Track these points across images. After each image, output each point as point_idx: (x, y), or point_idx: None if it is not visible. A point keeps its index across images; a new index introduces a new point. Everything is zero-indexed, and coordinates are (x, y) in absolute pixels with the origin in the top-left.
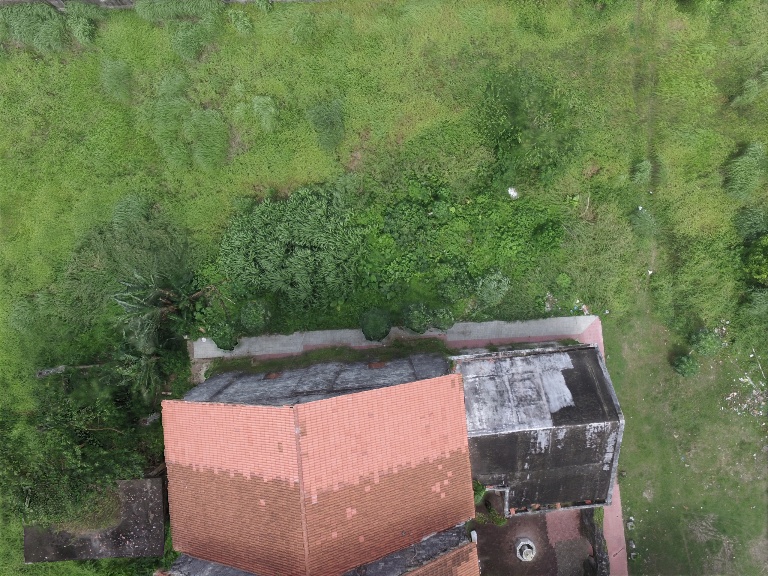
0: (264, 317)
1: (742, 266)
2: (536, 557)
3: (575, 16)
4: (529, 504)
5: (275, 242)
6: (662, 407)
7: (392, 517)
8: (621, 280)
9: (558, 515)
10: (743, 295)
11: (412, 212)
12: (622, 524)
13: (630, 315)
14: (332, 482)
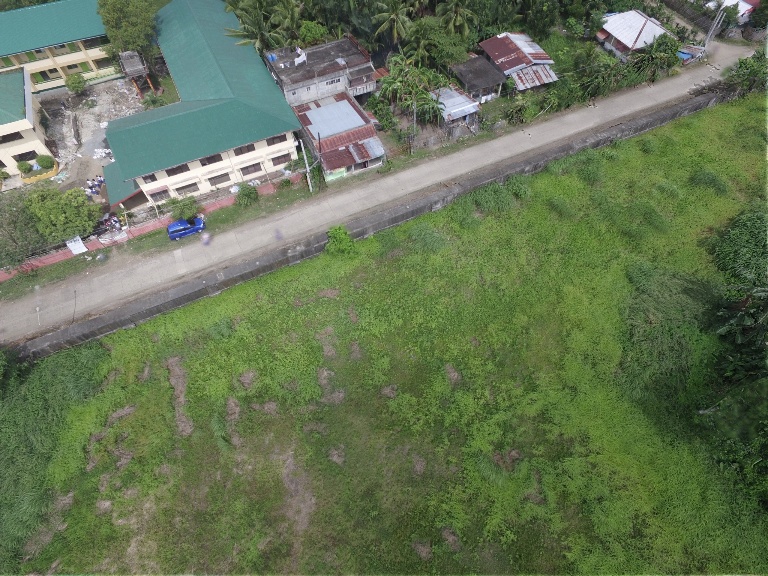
0: None
1: None
2: None
3: None
4: None
5: None
6: None
7: None
8: None
9: None
10: None
11: None
12: None
13: None
14: None
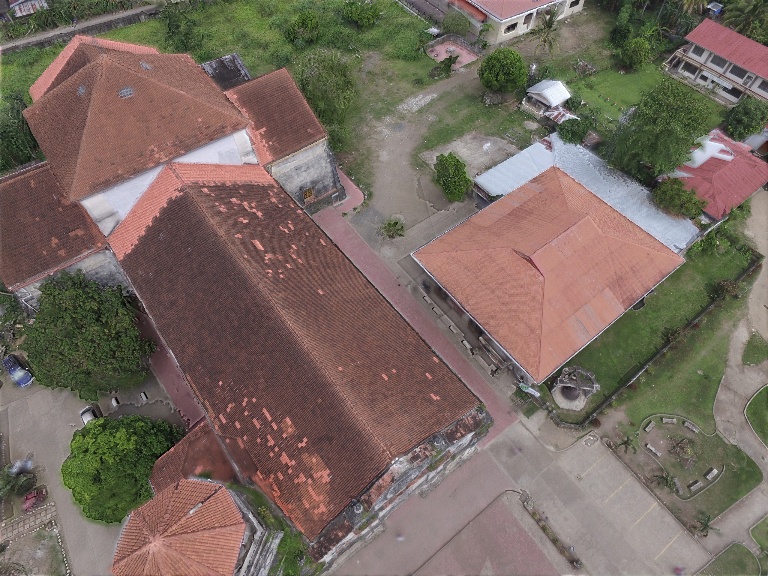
0: None
1: (287, 40)
2: None
3: None
4: None
5: None
6: None
7: None
8: None
9: None
10: None
11: None
12: None
13: (255, 67)
14: None
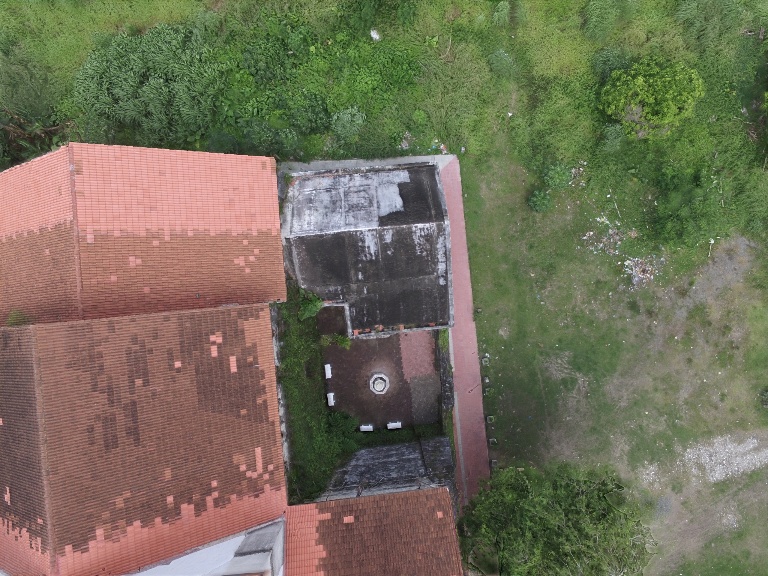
0: (106, 133)
1: (597, 104)
2: (391, 392)
3: None
4: (373, 325)
5: (128, 71)
6: (519, 246)
7: (185, 277)
8: (479, 120)
9: (413, 350)
10: (600, 136)
11: (268, 47)
12: (478, 361)
13: (489, 155)
14: (113, 227)
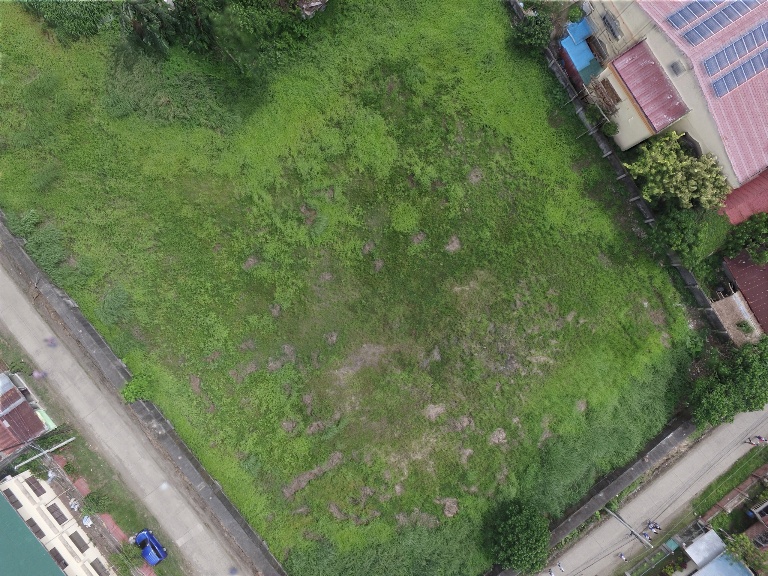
0: None
1: None
2: None
3: None
4: None
5: None
6: None
7: None
8: None
9: None
10: None
11: None
12: None
13: None
14: None
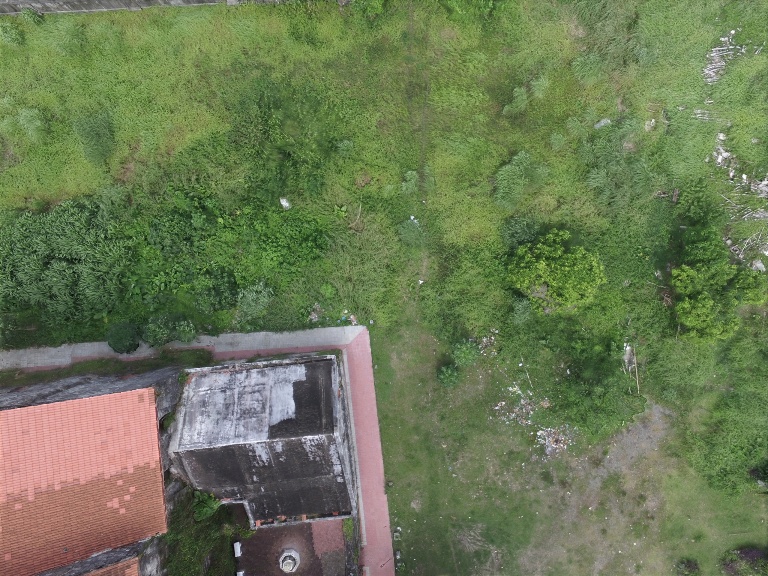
0: (2, 331)
1: (506, 275)
2: (302, 568)
3: (347, 26)
4: (275, 516)
5: (31, 255)
6: (430, 417)
7: (51, 534)
8: (389, 290)
9: (324, 526)
10: (511, 304)
11: (173, 224)
12: (390, 534)
13: (399, 325)
14: None
